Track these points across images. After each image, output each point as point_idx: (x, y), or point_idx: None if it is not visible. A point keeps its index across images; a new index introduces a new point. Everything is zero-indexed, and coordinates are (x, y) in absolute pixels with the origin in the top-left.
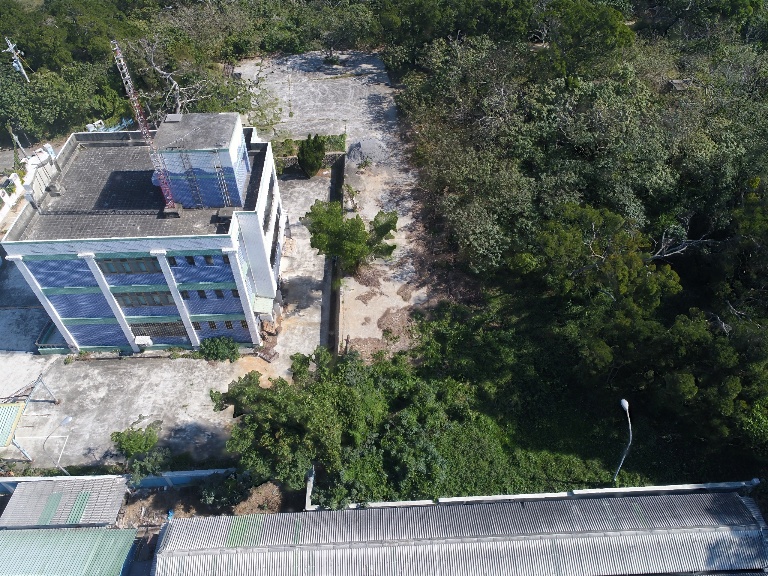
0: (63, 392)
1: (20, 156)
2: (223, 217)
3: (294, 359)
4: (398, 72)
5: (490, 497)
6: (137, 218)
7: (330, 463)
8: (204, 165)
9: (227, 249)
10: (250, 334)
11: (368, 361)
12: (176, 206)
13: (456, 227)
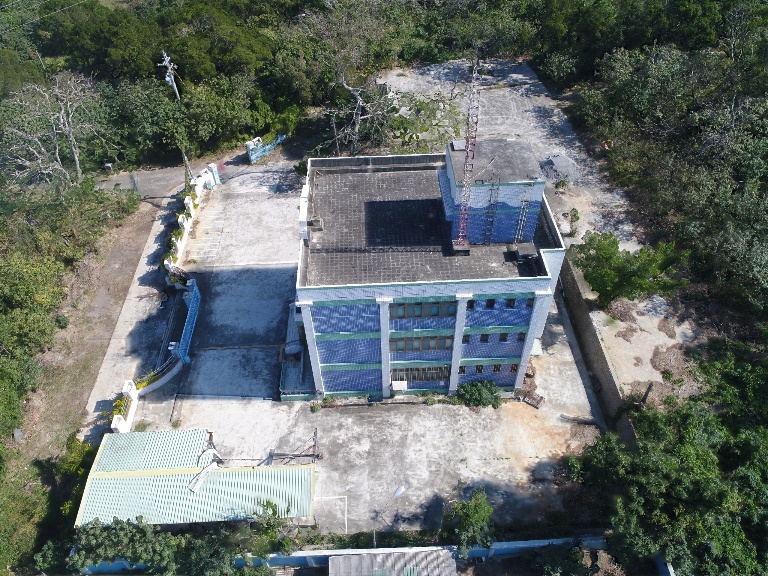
0: (322, 445)
1: (173, 176)
2: (524, 255)
3: (658, 420)
4: (558, 82)
5: None
6: (421, 256)
7: (697, 535)
8: (511, 199)
9: (541, 292)
10: (516, 377)
11: (661, 408)
12: (465, 242)
13: (705, 255)
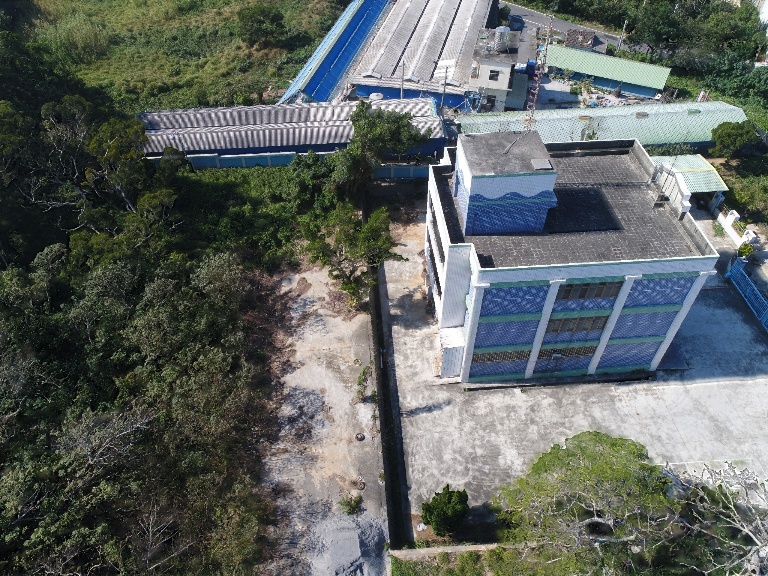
0: None
1: None
2: None
3: None
4: None
5: (266, 154)
6: None
7: None
8: None
9: None
10: None
11: None
12: None
13: None
